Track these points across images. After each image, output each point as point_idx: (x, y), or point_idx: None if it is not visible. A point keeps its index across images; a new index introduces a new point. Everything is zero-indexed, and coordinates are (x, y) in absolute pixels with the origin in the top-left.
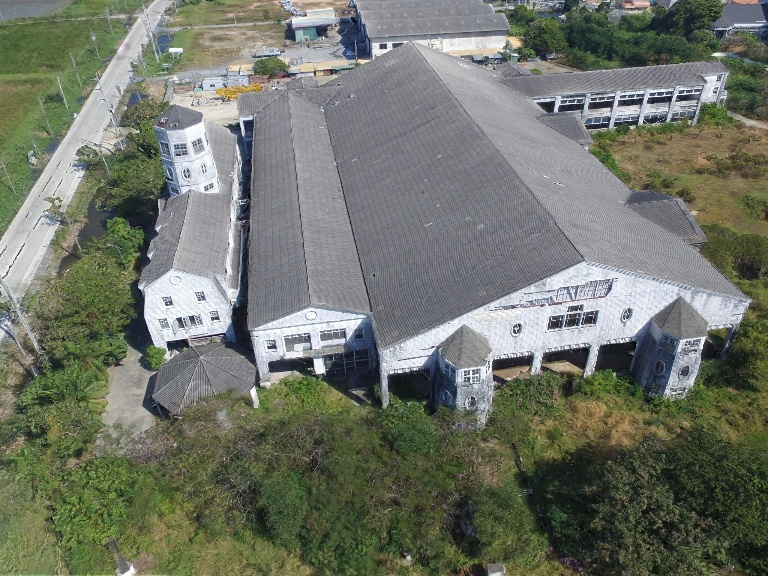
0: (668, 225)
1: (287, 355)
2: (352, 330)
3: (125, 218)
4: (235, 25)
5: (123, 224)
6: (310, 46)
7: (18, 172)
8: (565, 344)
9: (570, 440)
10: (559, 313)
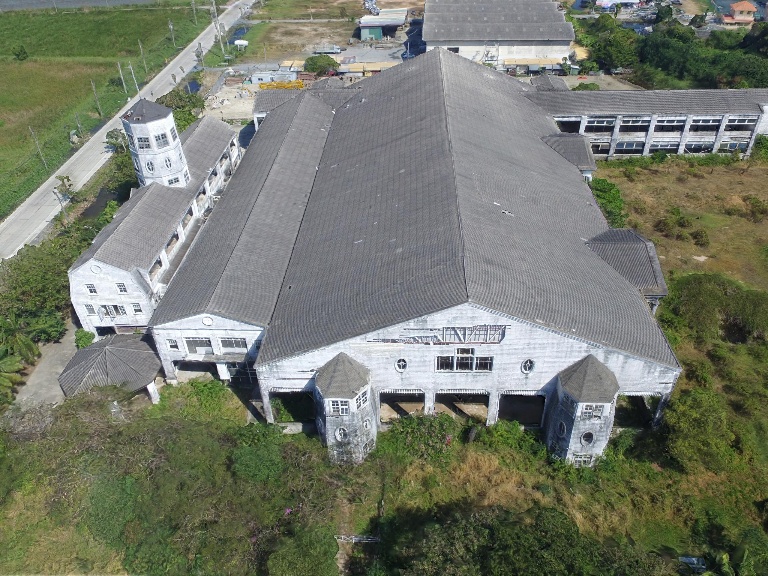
0: (627, 271)
1: (189, 356)
2: (252, 341)
3: (119, 202)
4: (311, 21)
5: (111, 208)
6: (372, 45)
7: (57, 149)
8: (459, 387)
9: (447, 491)
10: (447, 354)
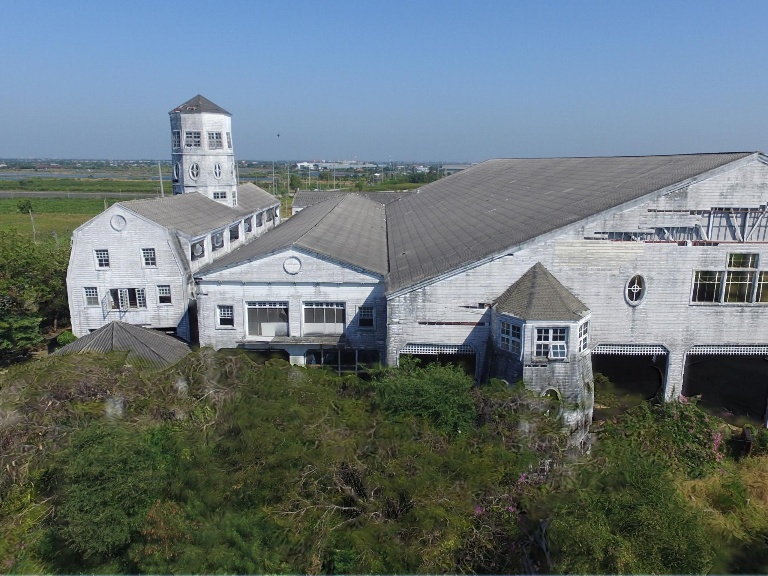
0: None
1: (248, 338)
2: (355, 307)
3: None
4: None
5: None
6: None
7: None
8: (727, 340)
9: (762, 517)
10: (713, 266)
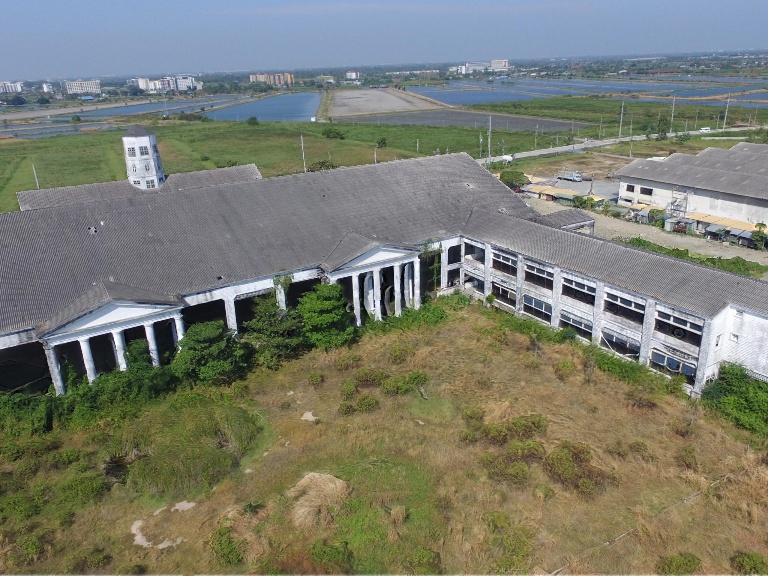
0: (68, 308)
1: None
2: None
3: None
4: (629, 158)
5: None
6: None
7: None
8: None
9: None
10: None
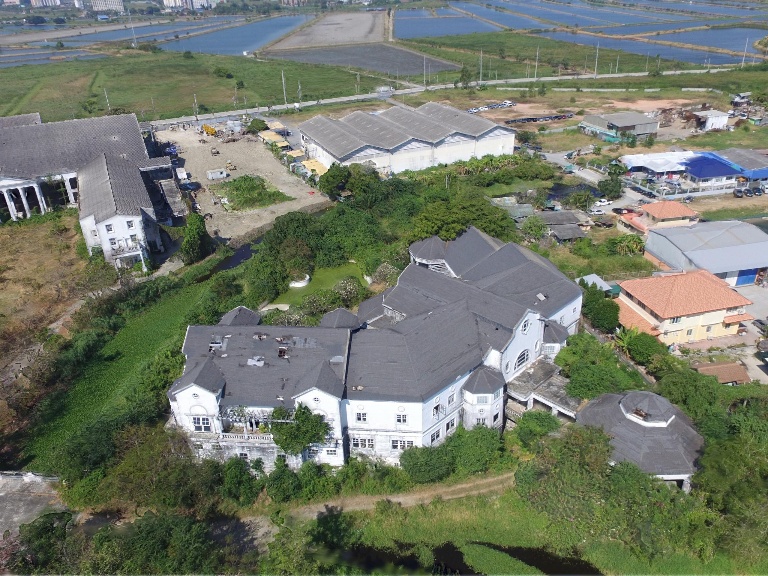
0: None
1: None
2: None
3: None
4: (403, 106)
5: None
6: None
7: None
8: None
9: None
10: None
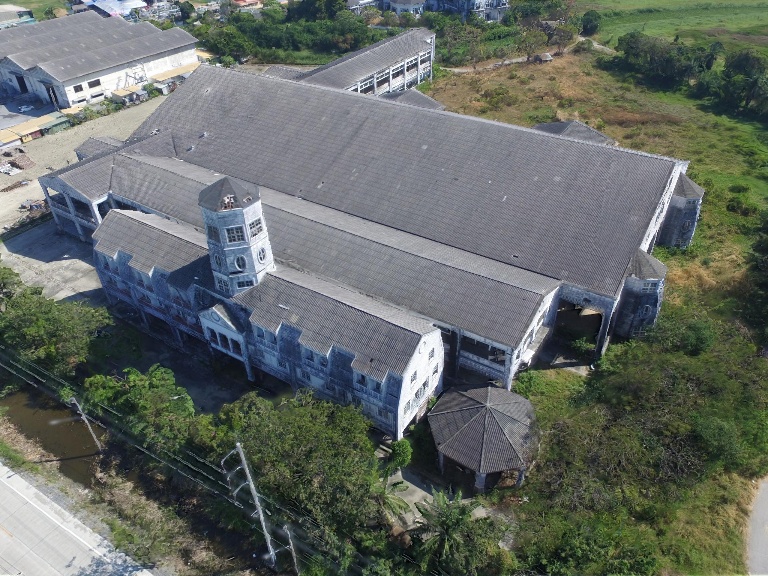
0: (591, 139)
1: (524, 359)
2: None
3: (102, 373)
4: None
5: (132, 375)
6: None
7: None
8: None
9: None
10: None
